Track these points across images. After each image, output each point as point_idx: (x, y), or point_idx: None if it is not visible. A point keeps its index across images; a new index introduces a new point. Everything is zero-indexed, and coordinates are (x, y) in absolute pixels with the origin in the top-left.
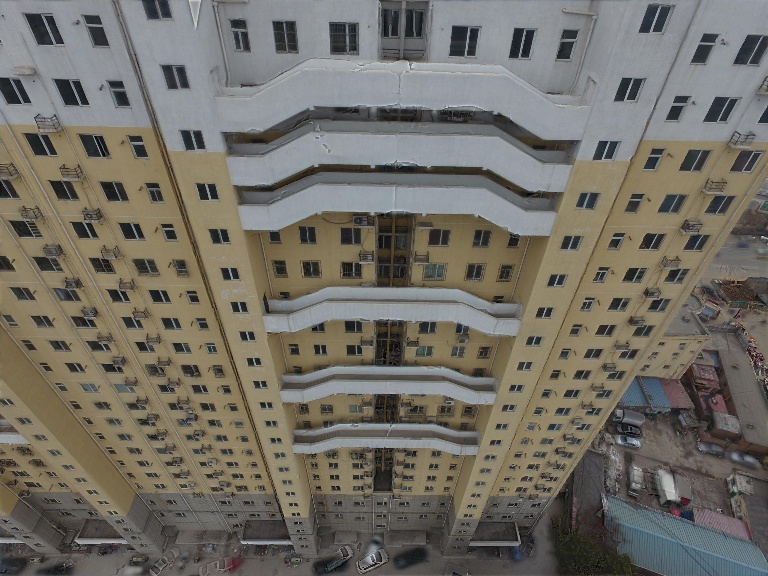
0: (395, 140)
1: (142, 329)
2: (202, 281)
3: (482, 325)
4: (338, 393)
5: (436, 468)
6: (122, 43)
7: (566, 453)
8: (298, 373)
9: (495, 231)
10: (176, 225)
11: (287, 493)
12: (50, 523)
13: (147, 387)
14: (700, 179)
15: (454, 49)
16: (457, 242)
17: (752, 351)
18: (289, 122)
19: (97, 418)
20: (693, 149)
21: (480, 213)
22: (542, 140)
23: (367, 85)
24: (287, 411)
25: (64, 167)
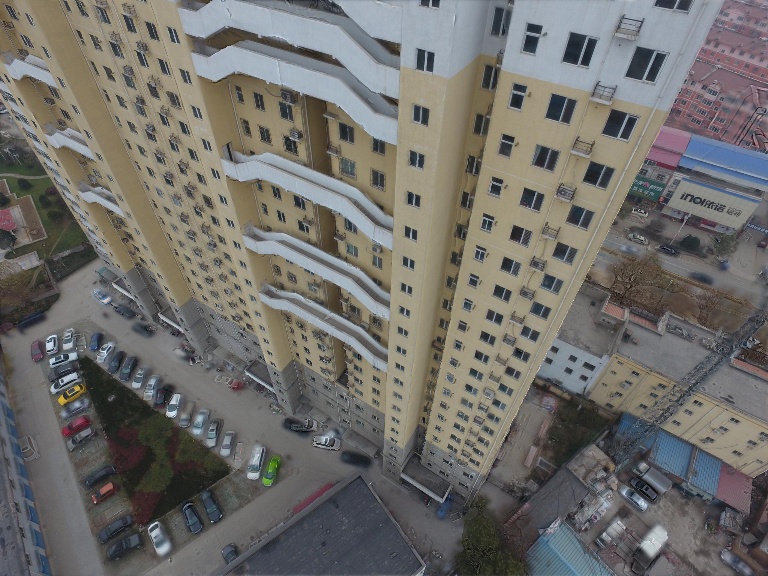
0: None
1: (179, 154)
2: None
3: (364, 227)
4: (278, 254)
5: (379, 383)
6: None
7: (487, 428)
8: (266, 231)
9: None
10: None
11: (264, 339)
12: (151, 296)
13: (187, 205)
14: (569, 134)
15: None
16: (360, 142)
17: None
18: None
19: (166, 220)
20: (556, 94)
21: (340, 104)
22: (370, 37)
23: None
24: (253, 259)
25: (124, 4)
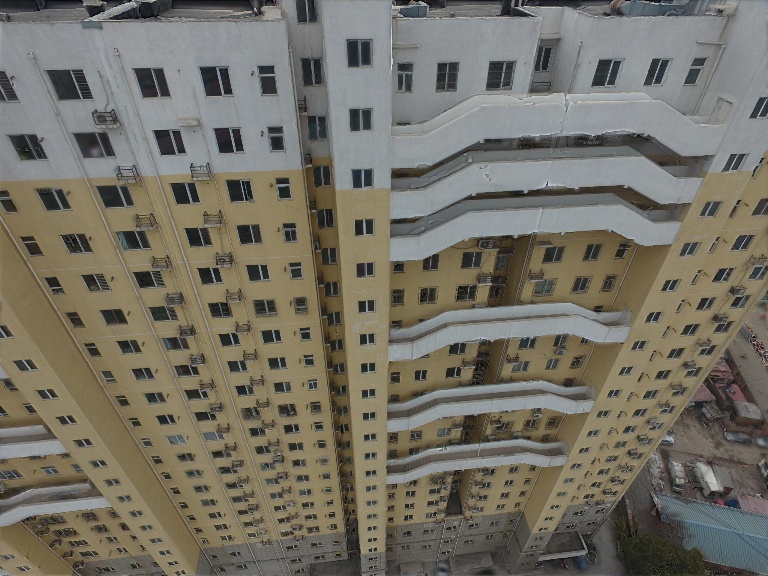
0: (550, 166)
1: (246, 372)
2: (318, 317)
3: (594, 335)
4: (444, 417)
5: (511, 484)
6: (291, 90)
7: None
8: (397, 401)
9: (606, 244)
10: (304, 263)
11: (369, 528)
12: None
13: (238, 432)
14: None
15: (595, 80)
16: (570, 257)
17: (752, 340)
18: (457, 155)
19: (177, 471)
20: None
21: (613, 228)
22: (681, 157)
23: (537, 117)
24: None
25: (207, 214)
